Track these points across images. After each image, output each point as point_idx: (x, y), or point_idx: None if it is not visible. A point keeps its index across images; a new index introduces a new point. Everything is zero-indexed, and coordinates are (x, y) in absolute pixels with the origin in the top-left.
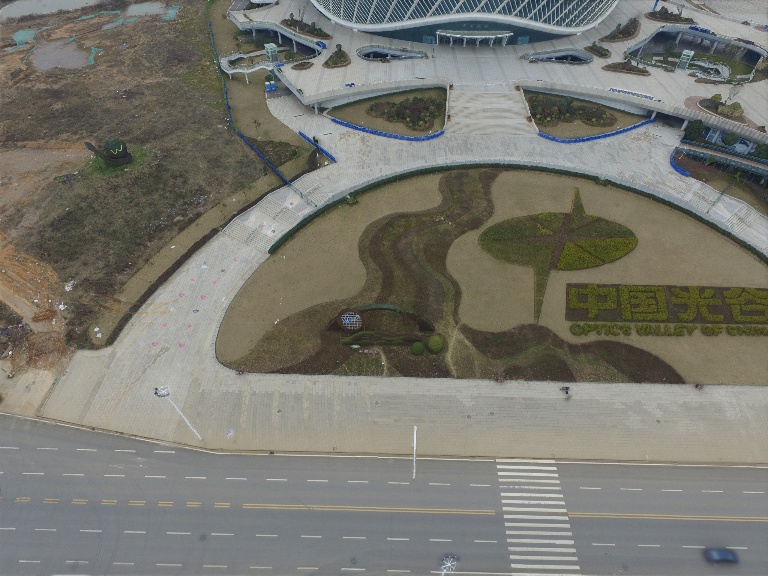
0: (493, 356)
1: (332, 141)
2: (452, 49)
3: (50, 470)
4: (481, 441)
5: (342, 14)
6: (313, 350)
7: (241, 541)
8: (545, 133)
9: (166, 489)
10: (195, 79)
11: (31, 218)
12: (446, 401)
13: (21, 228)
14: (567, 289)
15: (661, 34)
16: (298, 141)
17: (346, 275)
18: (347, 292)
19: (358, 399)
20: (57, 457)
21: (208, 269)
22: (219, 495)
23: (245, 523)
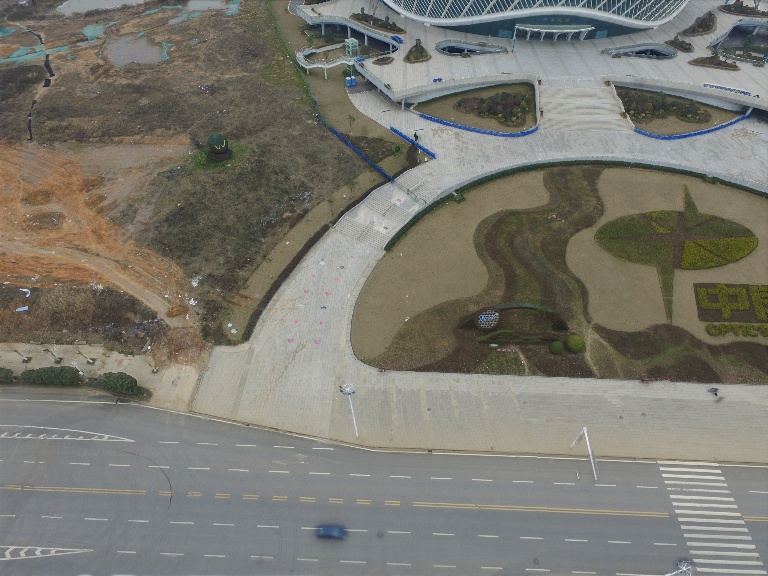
0: (633, 356)
1: (426, 137)
2: (530, 44)
3: (215, 465)
4: (639, 442)
5: (414, 8)
6: (450, 348)
7: (419, 539)
8: (641, 129)
9: (333, 486)
10: (274, 74)
11: (145, 213)
12: (595, 401)
13: (137, 223)
14: (695, 289)
15: (737, 28)
16: (391, 137)
17: (467, 273)
18: (472, 290)
19: (505, 398)
20: (218, 452)
21: (327, 266)
22: (387, 493)
23: (419, 521)
